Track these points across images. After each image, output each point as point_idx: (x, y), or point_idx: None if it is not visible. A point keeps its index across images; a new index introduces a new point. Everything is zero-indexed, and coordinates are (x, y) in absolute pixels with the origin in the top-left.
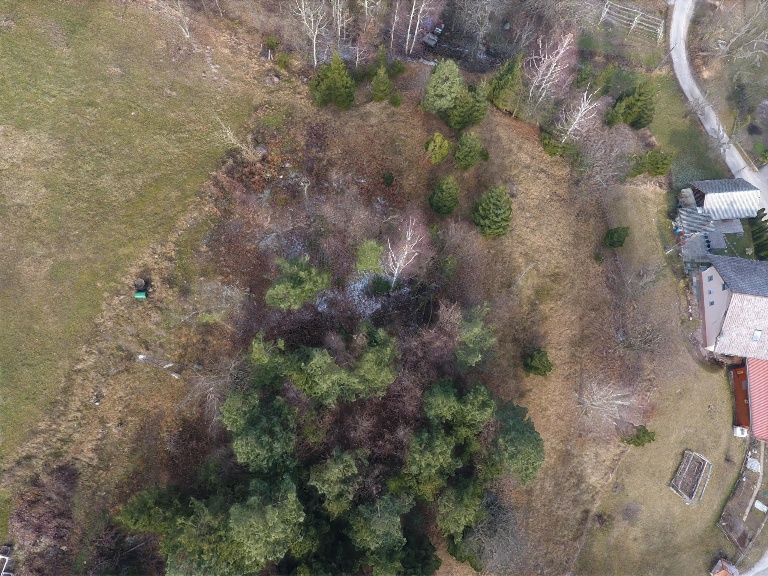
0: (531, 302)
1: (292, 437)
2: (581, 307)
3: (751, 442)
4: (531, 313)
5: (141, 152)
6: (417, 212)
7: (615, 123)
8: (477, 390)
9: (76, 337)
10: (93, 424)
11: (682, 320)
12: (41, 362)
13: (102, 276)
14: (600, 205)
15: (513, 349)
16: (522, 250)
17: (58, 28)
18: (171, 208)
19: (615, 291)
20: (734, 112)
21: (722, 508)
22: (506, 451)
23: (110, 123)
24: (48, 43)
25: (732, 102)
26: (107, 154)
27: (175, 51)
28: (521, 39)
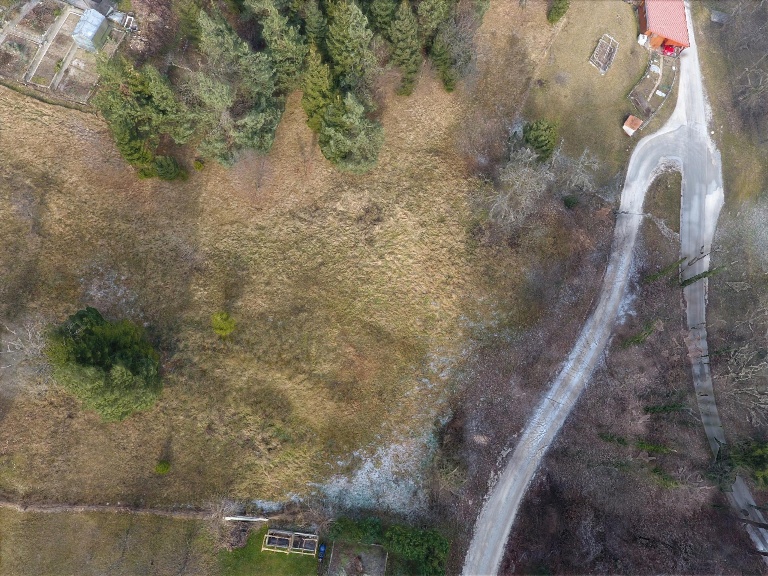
0: None
1: None
2: None
3: (653, 55)
4: None
5: None
6: None
7: None
8: None
9: None
10: None
11: None
12: None
13: None
14: None
15: None
16: None
17: None
18: None
19: None
20: None
21: (631, 89)
22: None
23: None
24: None
25: None
26: None
27: None
28: None
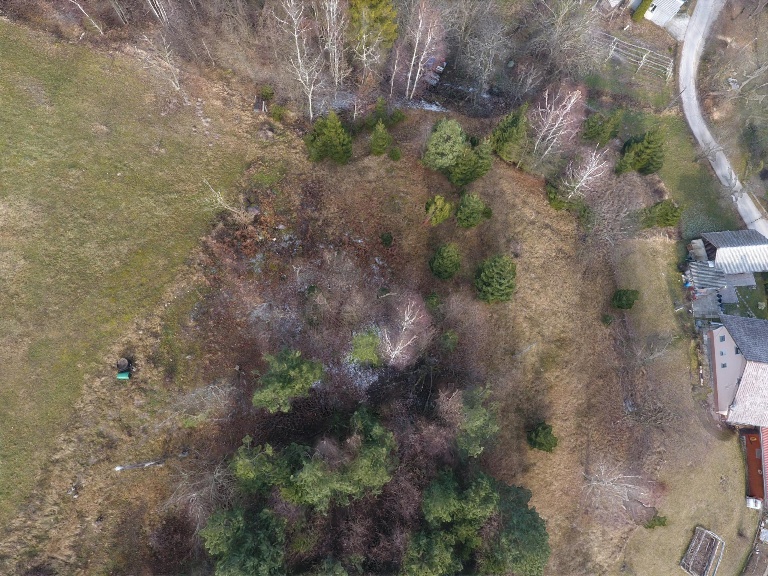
0: (535, 370)
1: (280, 552)
2: (588, 374)
3: (764, 512)
4: (535, 382)
5: (127, 216)
6: (417, 274)
7: (623, 172)
8: (479, 484)
9: (54, 424)
10: (71, 519)
11: (693, 386)
12: (16, 453)
13: (83, 356)
14: (608, 262)
15: (516, 420)
16: (526, 314)
17: (41, 84)
18: (157, 278)
19: (623, 355)
20: (746, 156)
21: None
22: (509, 552)
23: (94, 185)
24: (30, 101)
25: (744, 145)
26: (91, 220)
27: (164, 105)
28: (526, 82)
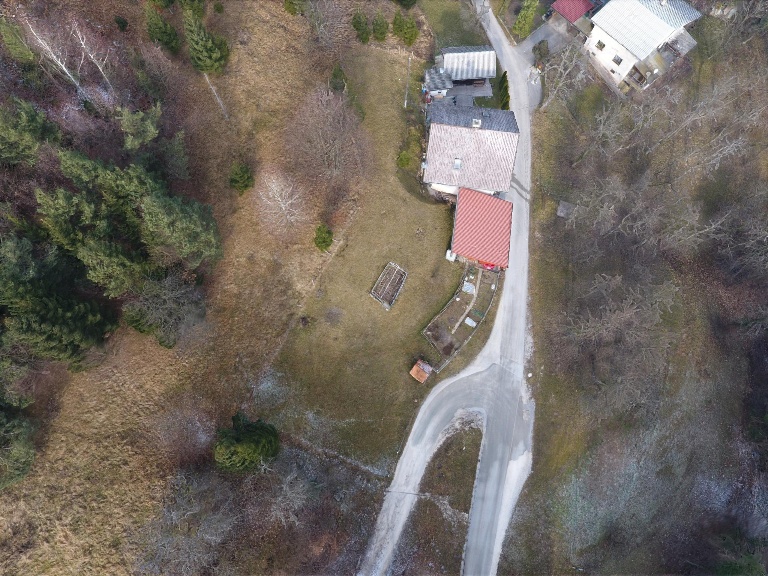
0: (248, 132)
1: None
2: (297, 138)
3: (469, 269)
4: (248, 142)
5: None
6: None
7: None
8: (130, 167)
9: None
10: None
11: (399, 156)
12: None
13: None
14: (337, 59)
15: None
16: (244, 88)
17: None
18: None
19: (337, 129)
20: None
21: (429, 320)
22: None
23: None
24: None
25: None
26: None
27: None
28: None
